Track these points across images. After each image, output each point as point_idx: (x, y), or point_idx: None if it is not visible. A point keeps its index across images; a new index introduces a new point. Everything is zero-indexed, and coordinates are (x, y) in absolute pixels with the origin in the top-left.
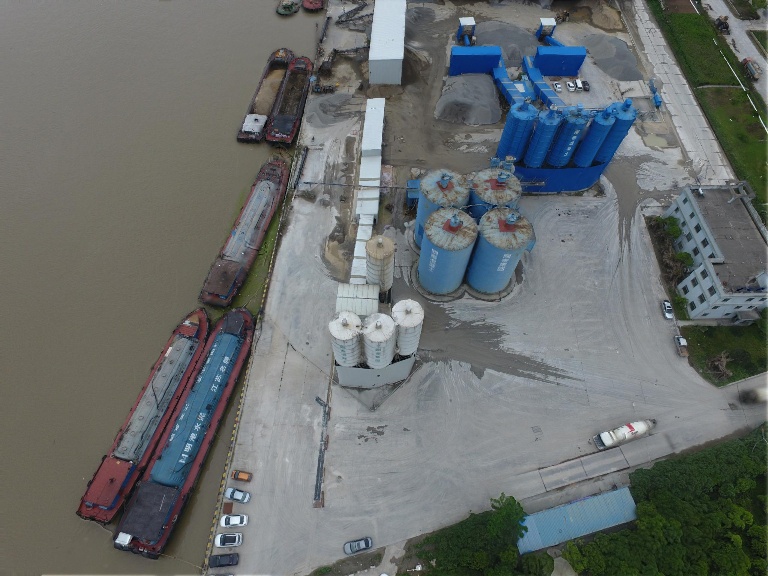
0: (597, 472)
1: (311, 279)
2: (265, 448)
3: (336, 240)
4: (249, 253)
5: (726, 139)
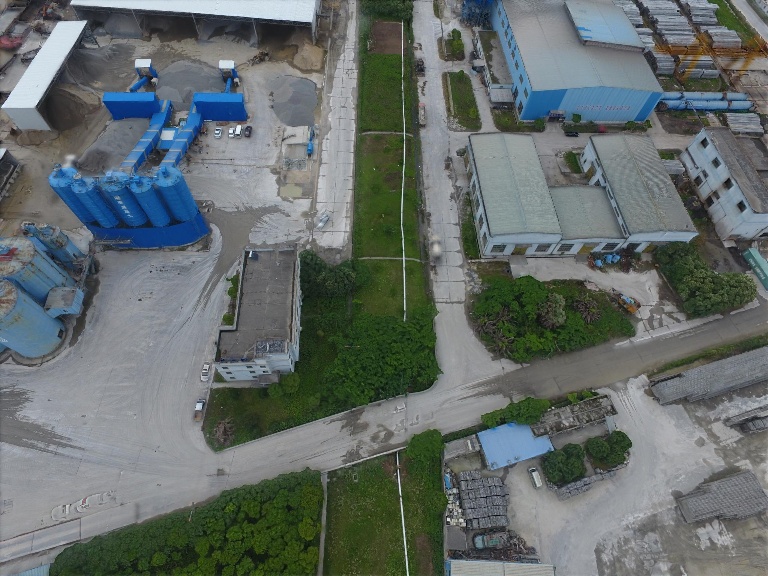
0: (44, 546)
1: None
2: None
3: None
4: None
5: (359, 189)
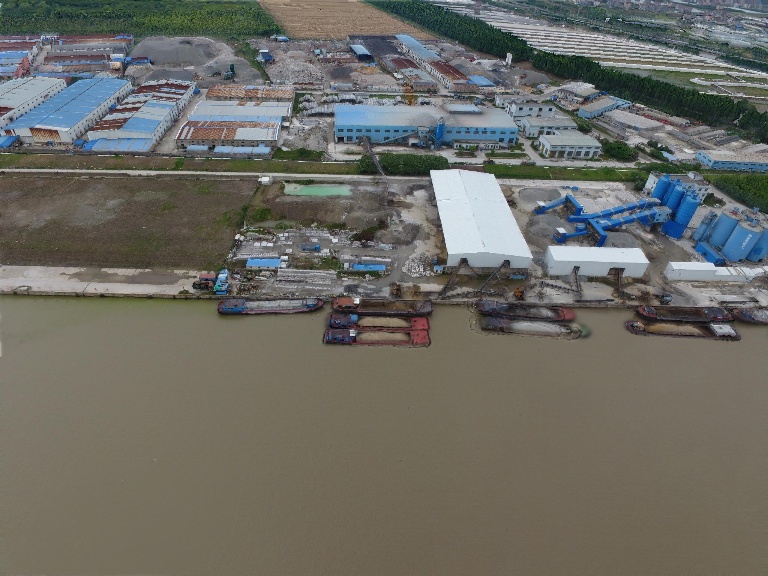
0: None
1: None
2: None
3: None
4: None
5: (589, 178)
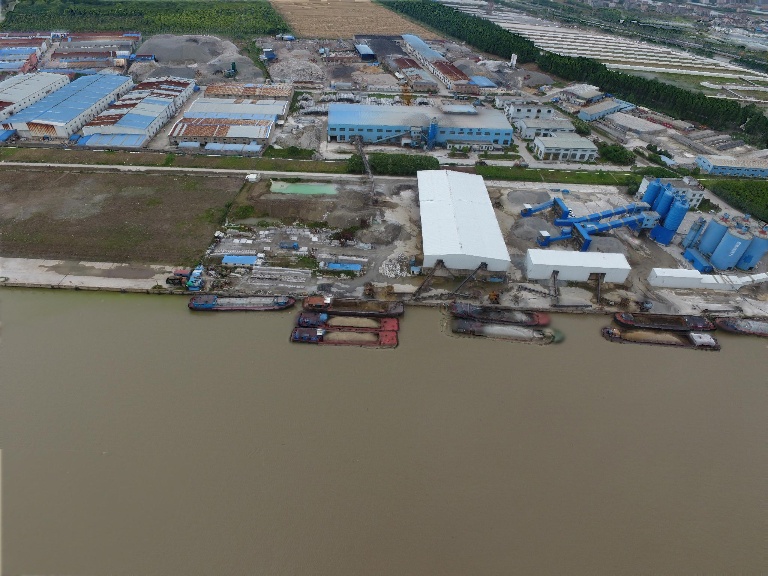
0: None
1: None
2: None
3: None
4: None
5: (581, 181)
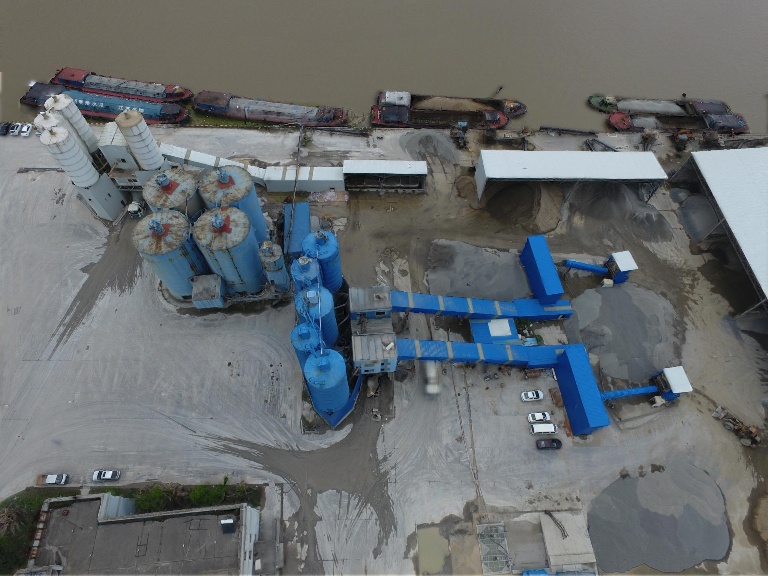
0: None
1: (210, 151)
2: None
3: (251, 164)
4: (241, 112)
5: None
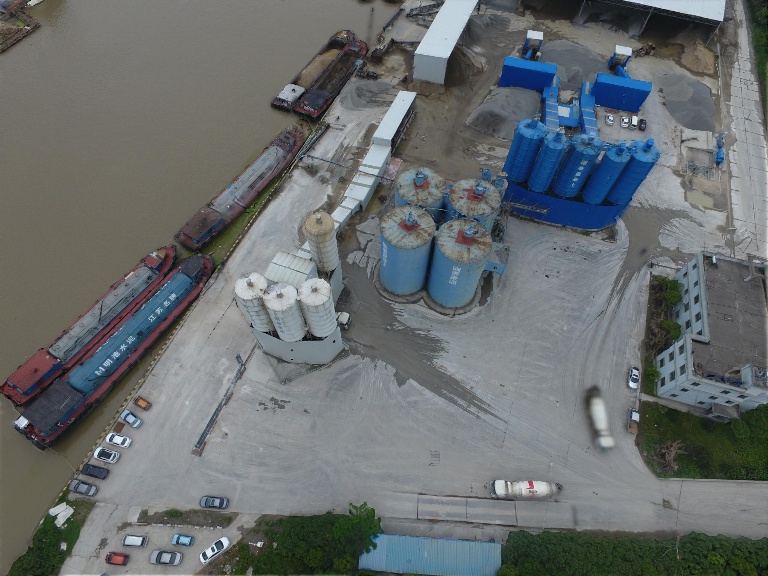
0: (479, 518)
1: (280, 246)
2: (173, 386)
3: None
4: (235, 208)
5: None
